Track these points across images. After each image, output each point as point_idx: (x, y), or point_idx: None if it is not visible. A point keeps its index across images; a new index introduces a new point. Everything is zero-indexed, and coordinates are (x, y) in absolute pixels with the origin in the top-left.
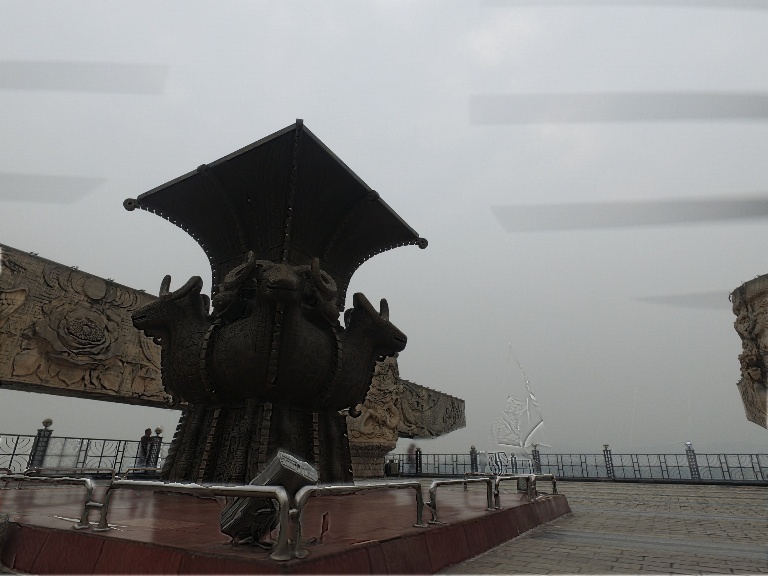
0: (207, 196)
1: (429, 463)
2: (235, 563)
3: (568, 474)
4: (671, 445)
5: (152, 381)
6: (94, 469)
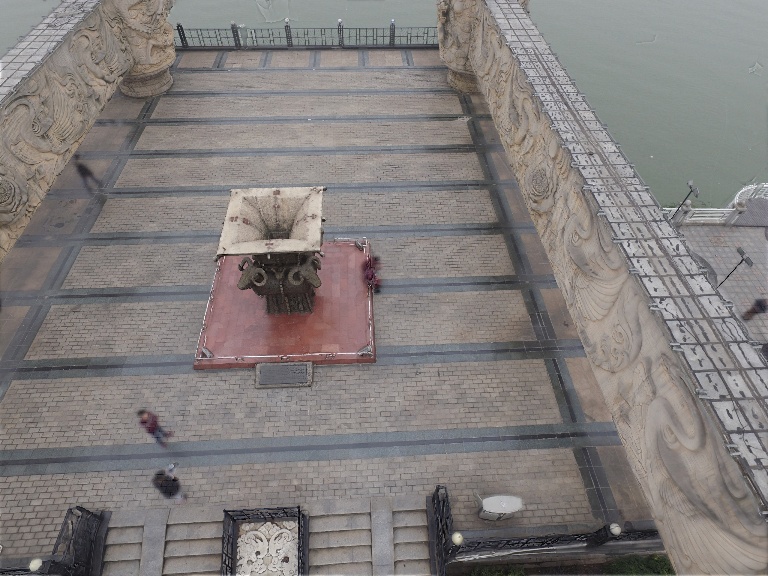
0: None
1: (193, 37)
2: (367, 359)
3: (312, 43)
4: (382, 20)
5: (45, 174)
6: None
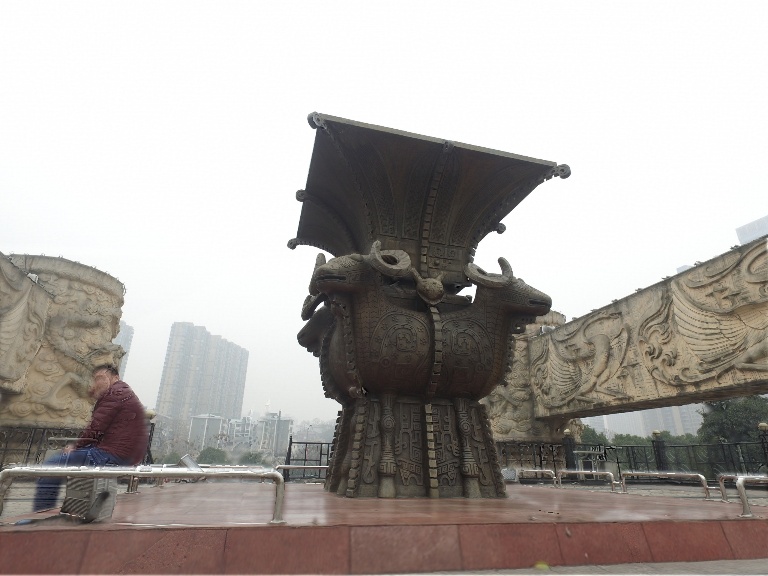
0: None
1: None
2: None
3: None
4: None
5: None
6: None
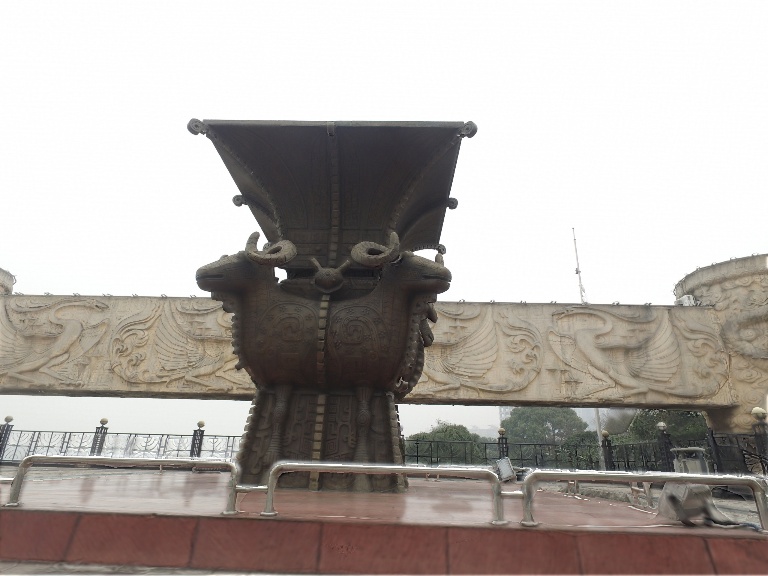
0: (431, 194)
1: None
2: None
3: None
4: None
5: None
6: (333, 468)
